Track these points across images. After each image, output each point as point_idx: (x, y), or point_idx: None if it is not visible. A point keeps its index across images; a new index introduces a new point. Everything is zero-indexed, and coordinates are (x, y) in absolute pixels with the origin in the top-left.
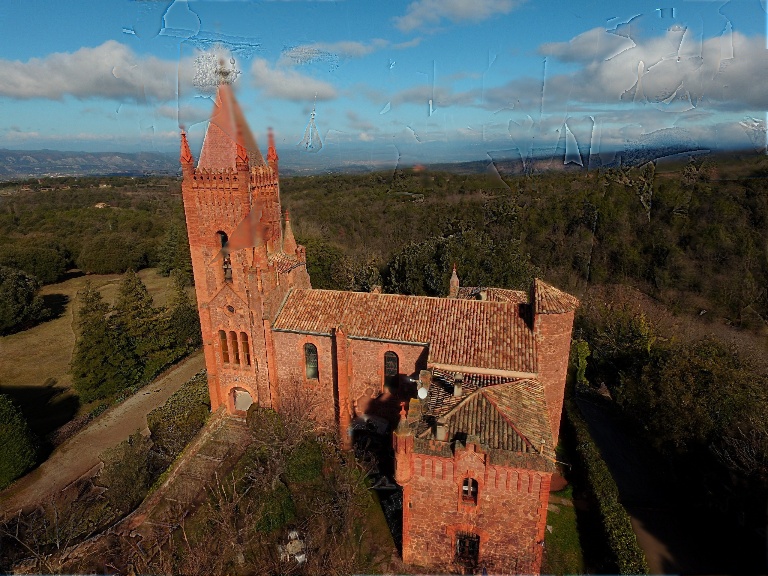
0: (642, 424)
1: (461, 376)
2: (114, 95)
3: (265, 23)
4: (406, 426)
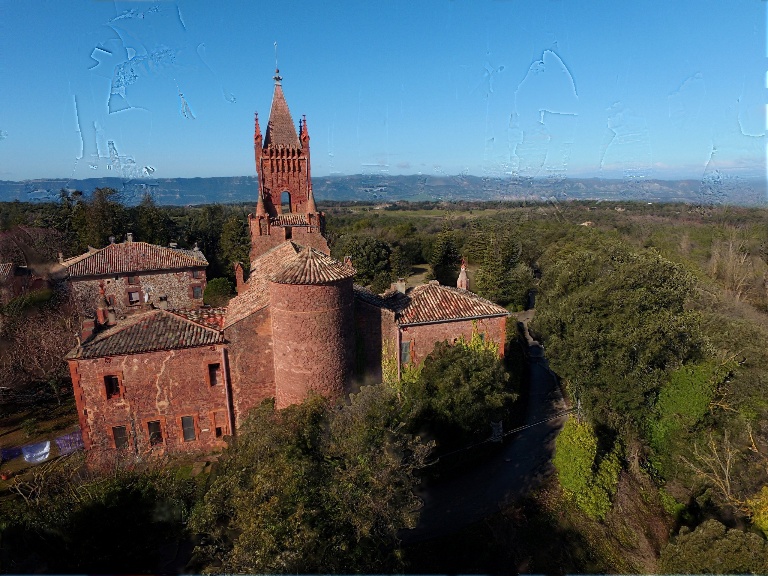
0: (503, 574)
1: (161, 295)
2: (405, 112)
3: None
4: (101, 302)
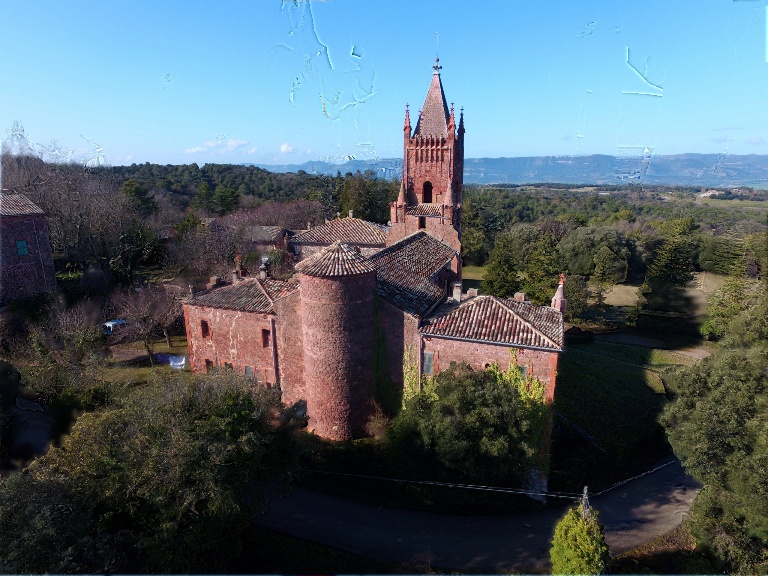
0: None
1: None
2: (651, 83)
3: None
4: None
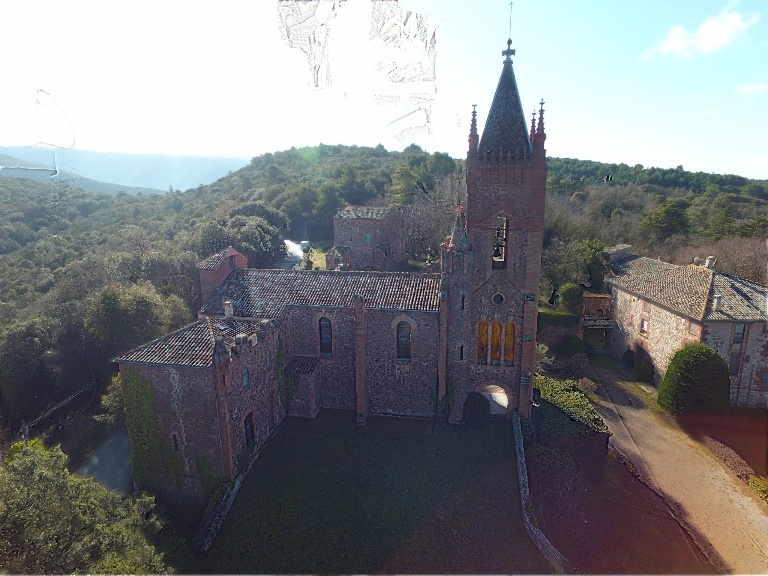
0: None
1: None
2: None
3: (406, 88)
4: None
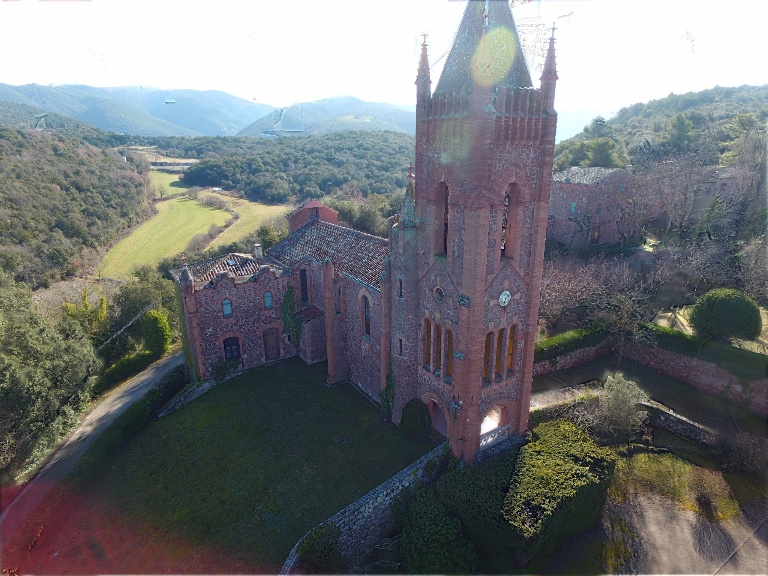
0: None
1: None
2: None
3: None
4: None
